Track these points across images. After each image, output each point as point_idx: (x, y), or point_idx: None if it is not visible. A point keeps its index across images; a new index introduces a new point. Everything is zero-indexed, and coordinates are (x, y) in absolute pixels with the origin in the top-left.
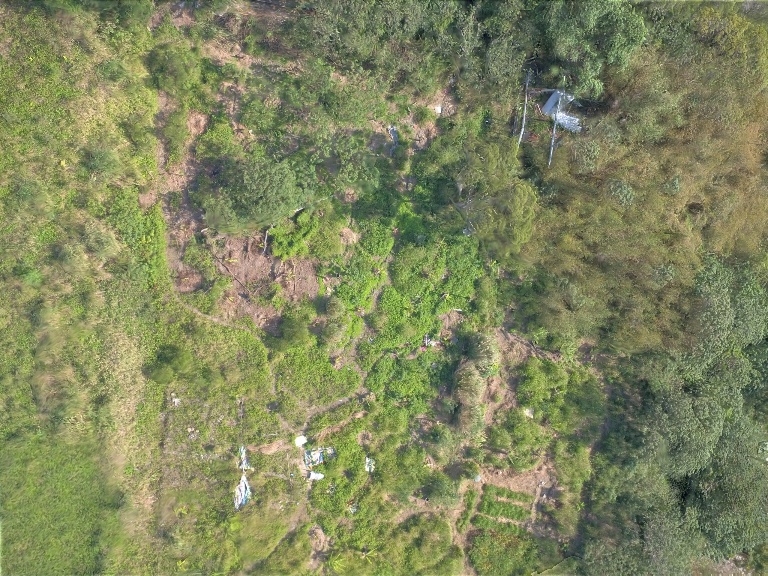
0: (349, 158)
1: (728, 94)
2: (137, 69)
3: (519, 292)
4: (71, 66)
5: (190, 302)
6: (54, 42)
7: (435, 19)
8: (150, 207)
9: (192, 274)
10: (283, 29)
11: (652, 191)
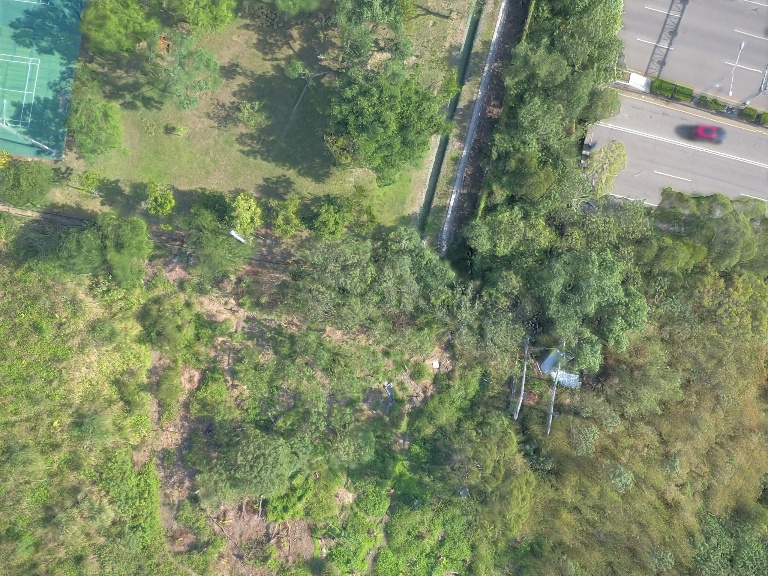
0: (345, 433)
1: (732, 371)
2: (130, 325)
3: (517, 555)
4: (63, 323)
5: (184, 563)
6: (46, 298)
7: (433, 295)
8: (144, 466)
9: (186, 534)
10: (278, 289)
11: (653, 466)
